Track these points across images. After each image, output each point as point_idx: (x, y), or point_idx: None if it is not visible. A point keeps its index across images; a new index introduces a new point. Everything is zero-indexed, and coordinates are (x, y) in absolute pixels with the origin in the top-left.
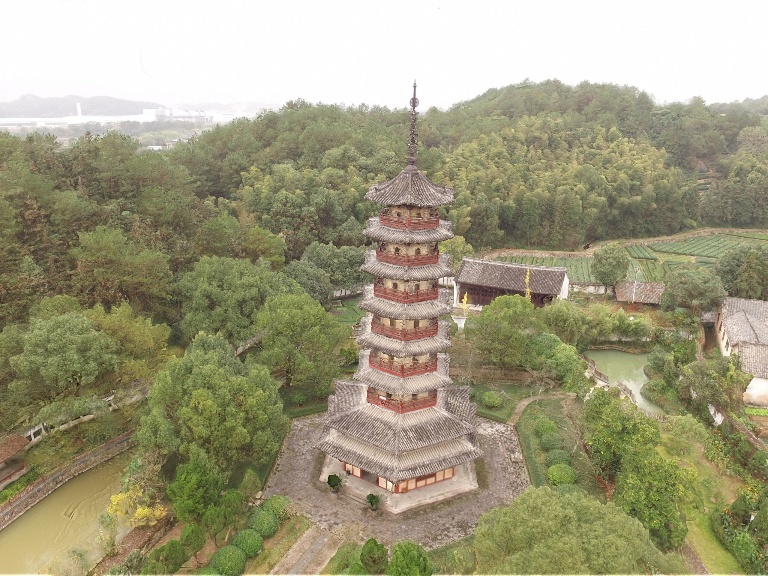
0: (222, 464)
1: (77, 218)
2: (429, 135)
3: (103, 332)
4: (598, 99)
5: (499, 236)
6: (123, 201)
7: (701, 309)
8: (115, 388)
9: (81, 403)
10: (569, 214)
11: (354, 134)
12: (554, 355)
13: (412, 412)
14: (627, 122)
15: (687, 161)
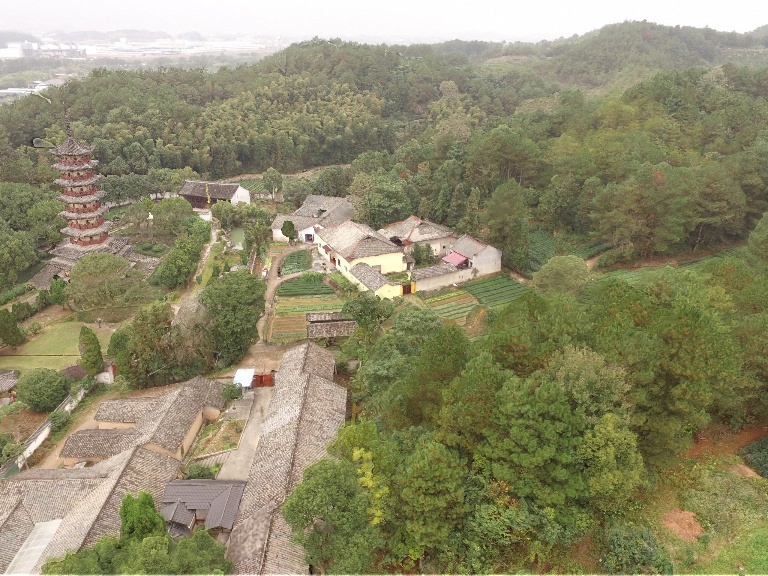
0: (0, 270)
1: None
2: (213, 91)
3: None
4: (347, 59)
5: (237, 166)
6: None
7: (297, 202)
8: None
9: None
10: (286, 149)
11: (130, 98)
12: None
13: (90, 246)
14: (367, 77)
15: (407, 106)
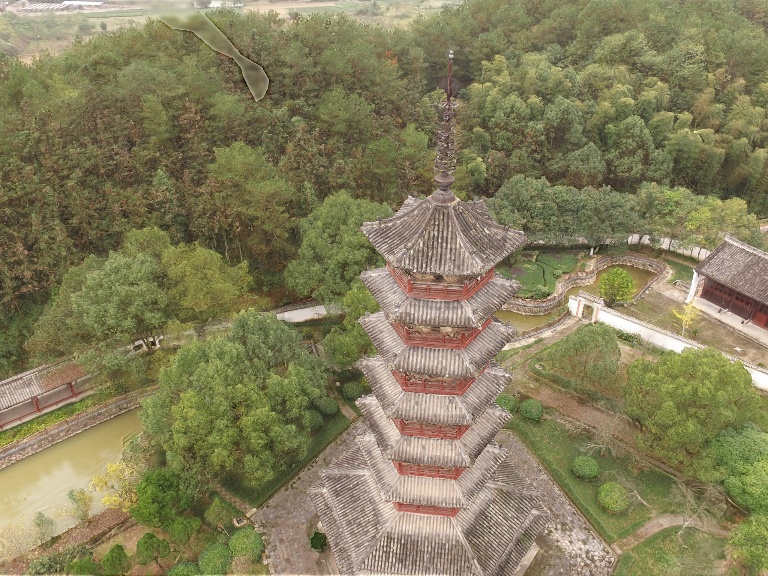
0: (208, 473)
1: (239, 123)
2: None
3: (156, 285)
4: None
5: None
6: (300, 103)
7: None
8: (236, 311)
9: (112, 359)
10: None
11: (652, 14)
12: (746, 473)
13: (416, 513)
14: None
15: None
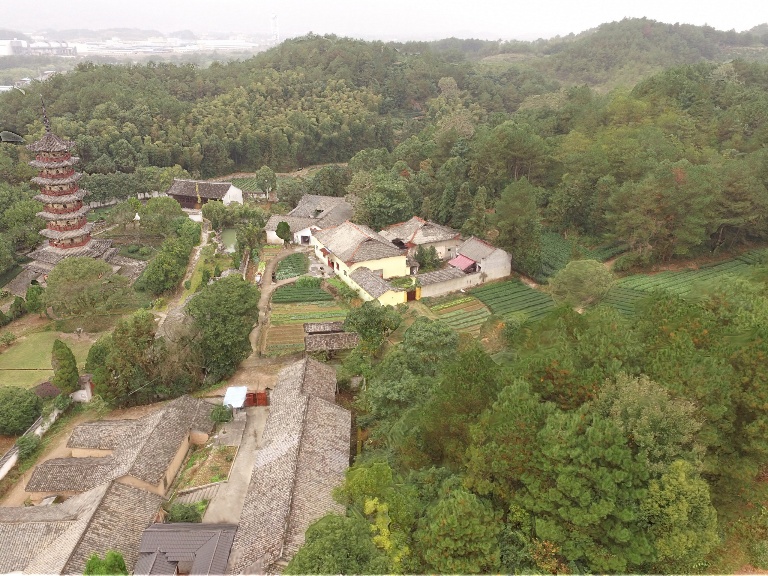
0: None
1: None
2: (204, 87)
3: None
4: (342, 55)
5: (229, 164)
6: None
7: (293, 202)
8: None
9: None
10: (280, 147)
11: (117, 93)
12: None
13: (71, 249)
14: (364, 73)
15: (405, 103)
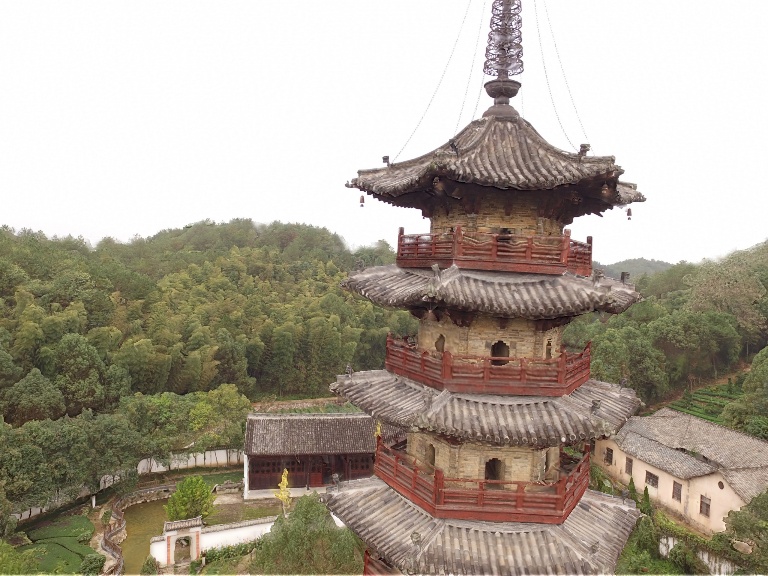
0: None
1: None
2: None
3: None
4: (301, 236)
5: (250, 385)
6: None
7: None
8: None
9: None
10: (327, 350)
11: (15, 247)
12: None
13: None
14: (332, 260)
15: None
